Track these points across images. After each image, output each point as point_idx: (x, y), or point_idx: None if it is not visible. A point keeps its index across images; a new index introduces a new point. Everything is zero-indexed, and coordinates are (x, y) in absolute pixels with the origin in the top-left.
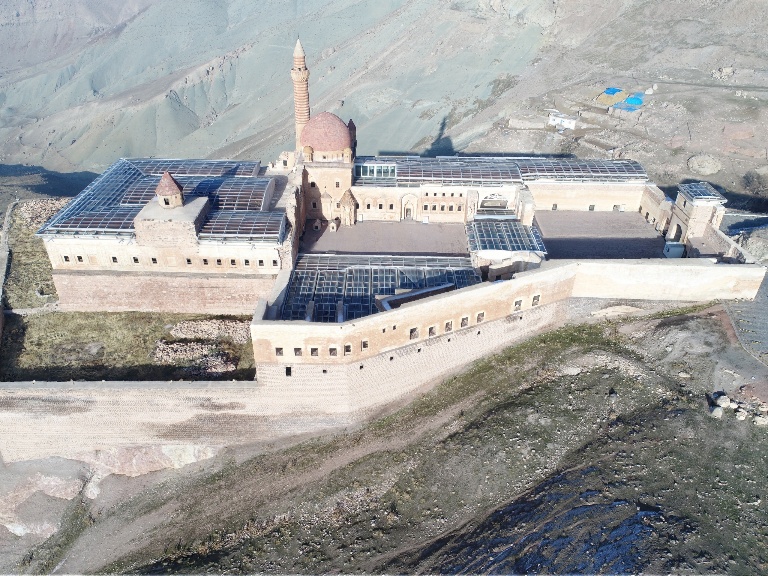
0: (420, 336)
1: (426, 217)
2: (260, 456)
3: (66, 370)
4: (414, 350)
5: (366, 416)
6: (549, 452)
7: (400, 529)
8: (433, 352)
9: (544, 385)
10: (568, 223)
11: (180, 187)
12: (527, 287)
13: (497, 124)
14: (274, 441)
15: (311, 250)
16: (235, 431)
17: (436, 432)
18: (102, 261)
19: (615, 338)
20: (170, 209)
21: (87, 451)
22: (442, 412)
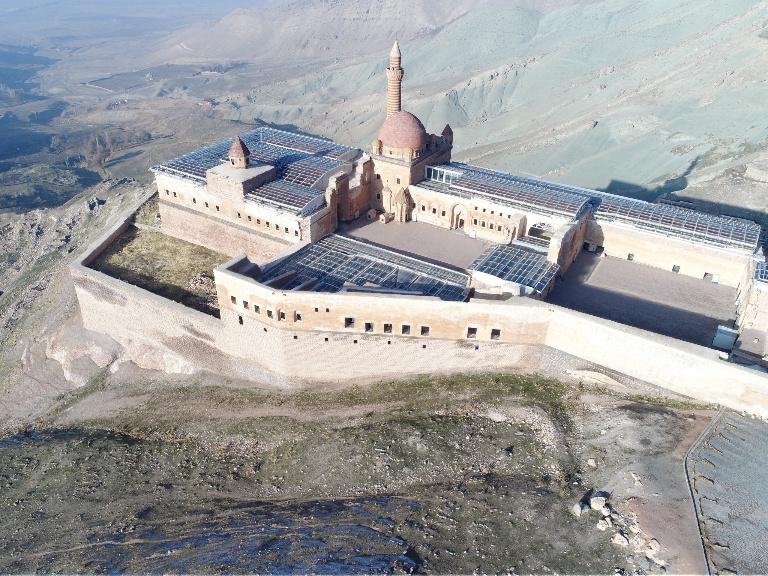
0: (356, 328)
1: (474, 231)
2: (217, 386)
3: (130, 273)
4: (350, 339)
5: (303, 386)
6: (400, 475)
7: (247, 481)
8: (372, 349)
9: (456, 418)
10: (631, 277)
11: (246, 152)
12: (482, 316)
13: (731, 170)
14: (233, 379)
15: (348, 233)
16: (209, 359)
17: (339, 420)
18: (187, 200)
19: (570, 403)
20: (235, 169)
21: (125, 338)
22: (358, 406)
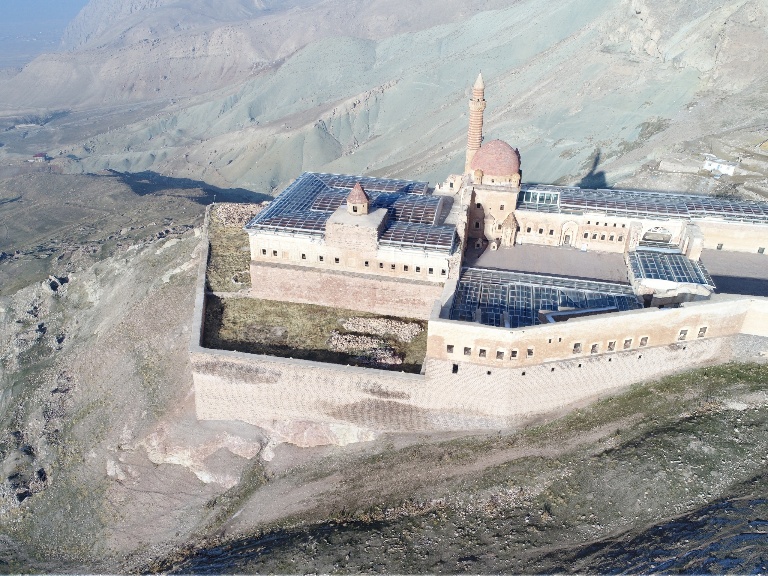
0: (583, 352)
1: (585, 245)
2: (417, 445)
3: (257, 346)
4: (575, 365)
5: (520, 422)
6: (713, 479)
7: (555, 529)
8: (593, 369)
9: (707, 416)
10: (735, 263)
11: (367, 197)
12: (695, 317)
13: (646, 166)
14: (431, 434)
15: (473, 265)
16: (396, 419)
17: (591, 446)
18: (293, 257)
19: None
20: (357, 216)
21: (266, 419)
22: (597, 428)
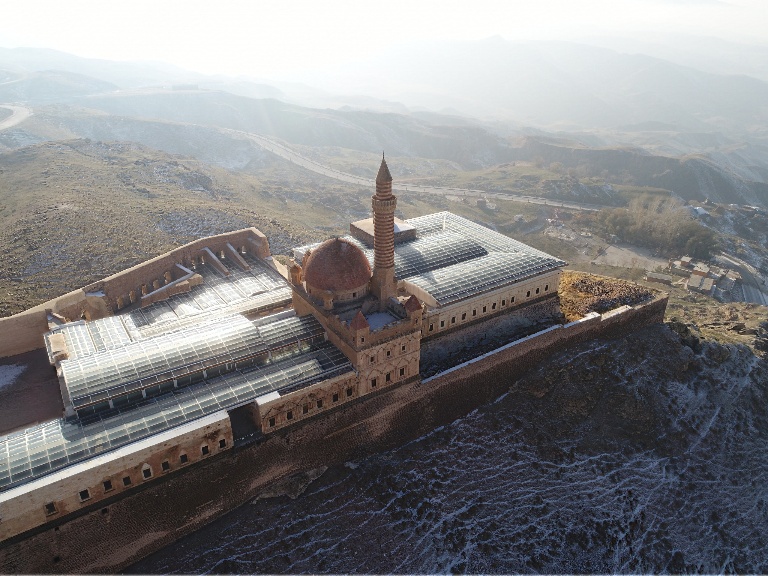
0: None
1: None
2: None
3: None
4: None
5: None
6: None
7: None
8: None
9: None
10: None
11: None
12: None
13: None
14: None
15: None
16: None
17: None
18: None
19: None
20: None
21: None
22: None
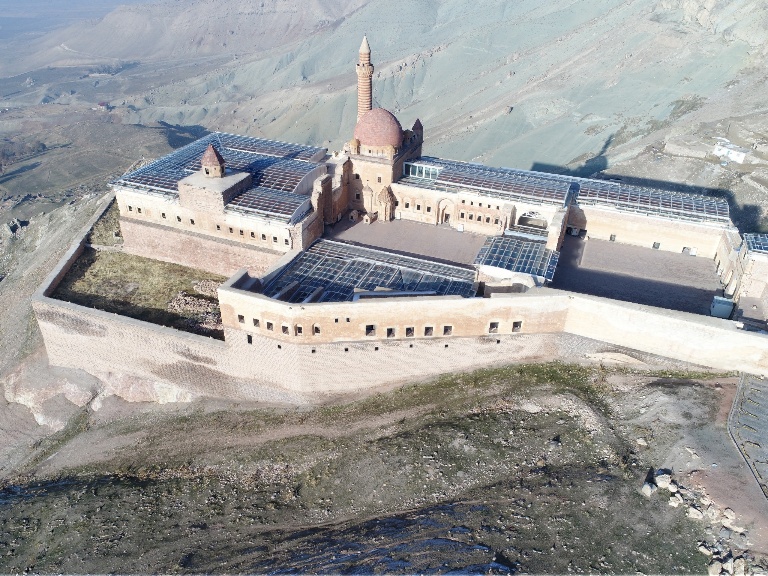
0: (377, 335)
1: (461, 225)
2: (223, 411)
3: (101, 300)
4: (371, 347)
5: (320, 400)
6: (456, 479)
7: (290, 508)
8: (393, 354)
9: (493, 414)
10: (618, 257)
11: (221, 160)
12: (505, 310)
13: (651, 147)
14: (239, 402)
15: (335, 237)
16: (210, 384)
17: (371, 431)
18: (155, 215)
19: (598, 386)
20: (209, 178)
21: (103, 371)
22: (386, 415)
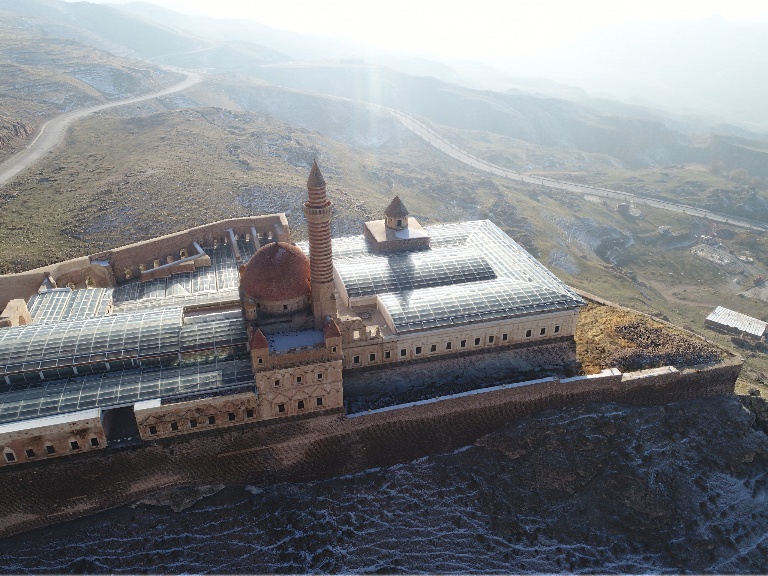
0: None
1: None
2: None
3: None
4: None
5: None
6: None
7: None
8: None
9: None
10: None
11: (387, 211)
12: None
13: None
14: None
15: None
16: None
17: None
18: None
19: None
20: None
21: None
22: None
